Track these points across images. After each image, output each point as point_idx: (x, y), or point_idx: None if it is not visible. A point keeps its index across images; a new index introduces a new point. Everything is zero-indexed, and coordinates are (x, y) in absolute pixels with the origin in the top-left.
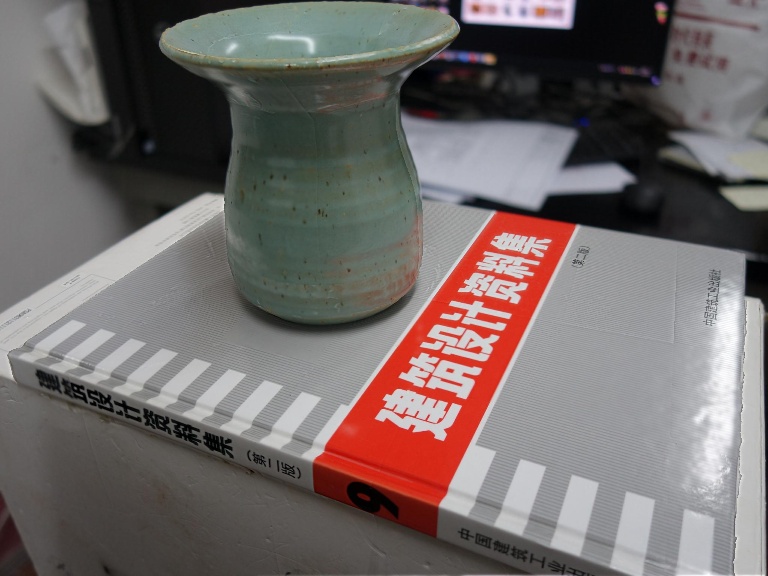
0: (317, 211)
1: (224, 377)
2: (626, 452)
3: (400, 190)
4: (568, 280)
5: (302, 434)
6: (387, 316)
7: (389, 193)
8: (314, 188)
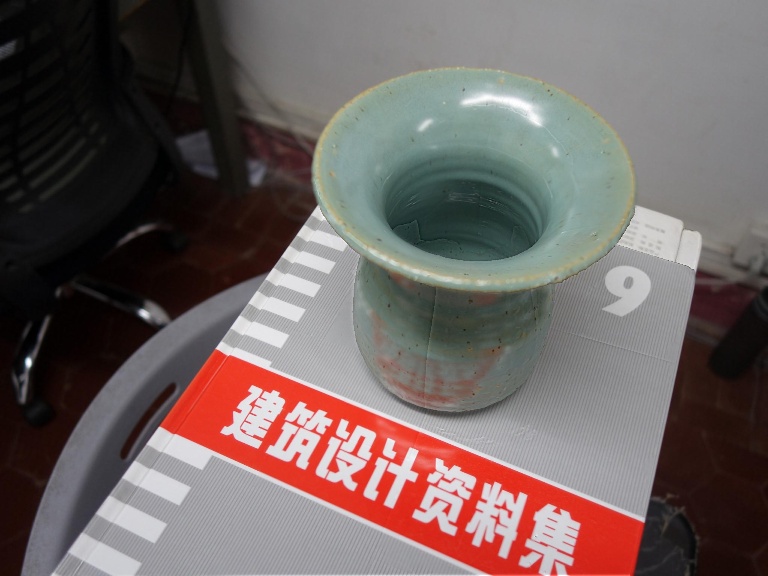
0: (359, 270)
1: (311, 284)
2: (181, 575)
3: (404, 333)
4: None
5: (243, 339)
6: None
7: (391, 322)
8: None
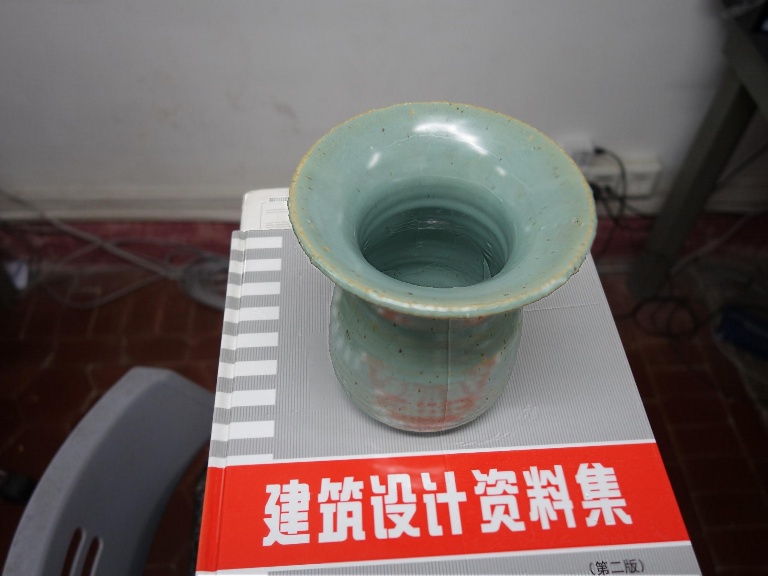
0: (346, 330)
1: (267, 362)
2: None
3: (422, 370)
4: (557, 568)
5: (231, 445)
6: (399, 430)
7: (406, 366)
8: (351, 314)
